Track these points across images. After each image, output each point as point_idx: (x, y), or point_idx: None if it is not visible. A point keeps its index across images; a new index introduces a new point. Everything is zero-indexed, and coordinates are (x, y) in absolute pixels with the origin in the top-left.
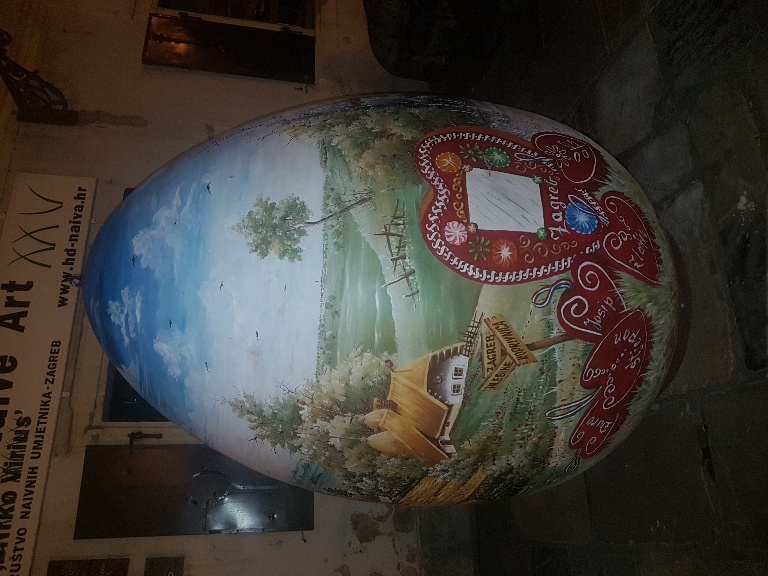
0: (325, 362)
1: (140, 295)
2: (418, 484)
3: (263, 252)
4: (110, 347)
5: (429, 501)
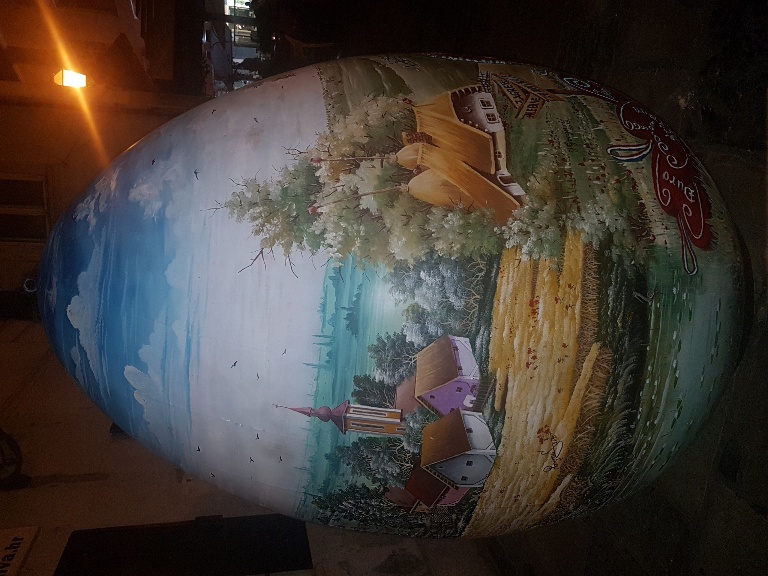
0: (336, 113)
1: (118, 168)
2: (499, 273)
3: None
4: (66, 264)
5: (531, 349)
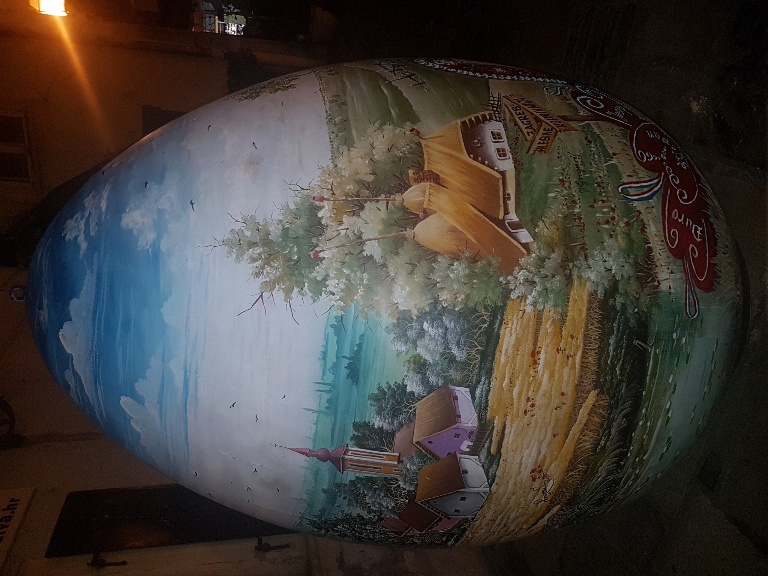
0: (340, 144)
1: (109, 185)
2: (503, 324)
3: (253, 97)
4: (57, 286)
5: (530, 398)
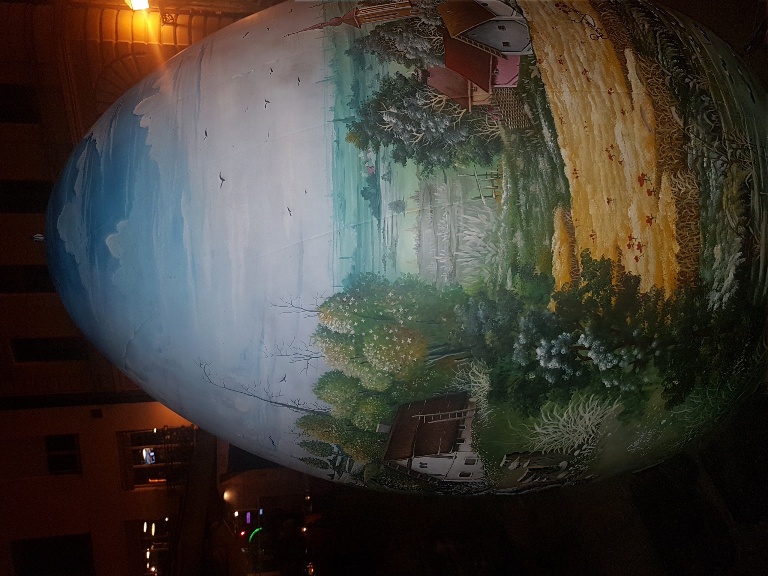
0: None
1: None
2: None
3: None
4: None
5: None
